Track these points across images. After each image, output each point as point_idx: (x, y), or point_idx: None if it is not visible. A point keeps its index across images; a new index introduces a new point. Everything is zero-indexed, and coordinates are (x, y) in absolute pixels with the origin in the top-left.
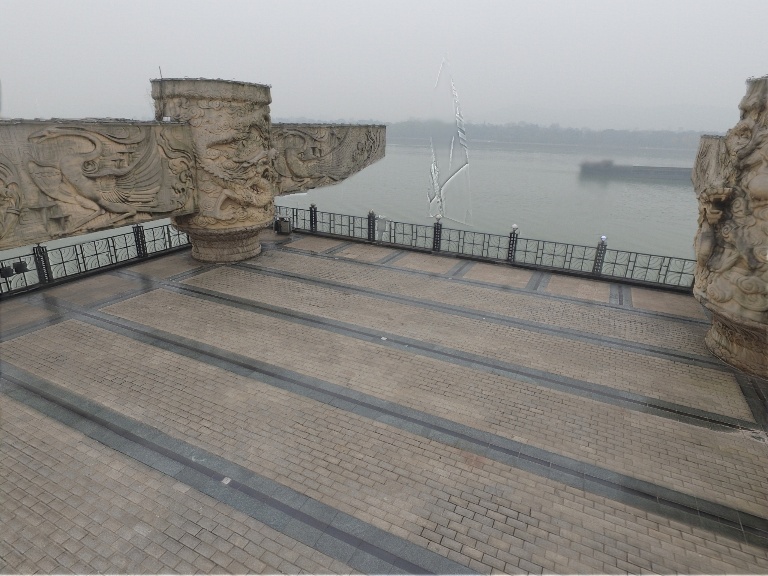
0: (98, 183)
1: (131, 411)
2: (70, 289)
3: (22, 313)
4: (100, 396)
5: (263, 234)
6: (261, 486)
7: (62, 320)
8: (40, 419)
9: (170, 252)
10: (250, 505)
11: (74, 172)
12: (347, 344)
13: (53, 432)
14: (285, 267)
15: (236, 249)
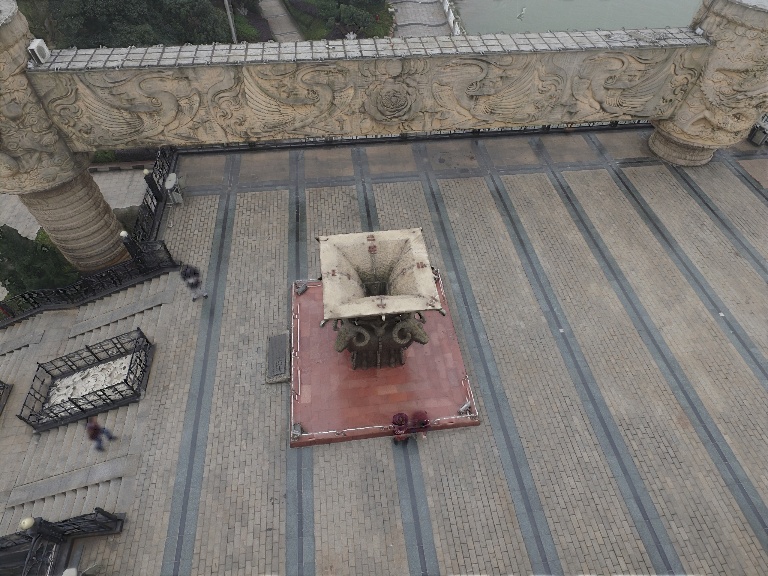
0: (609, 92)
1: (544, 263)
2: (555, 141)
3: (524, 153)
4: (535, 244)
5: None
6: (573, 345)
7: (540, 171)
8: (509, 242)
9: (635, 127)
10: (563, 349)
11: (598, 84)
12: (689, 300)
13: (511, 253)
14: (714, 193)
15: (685, 155)
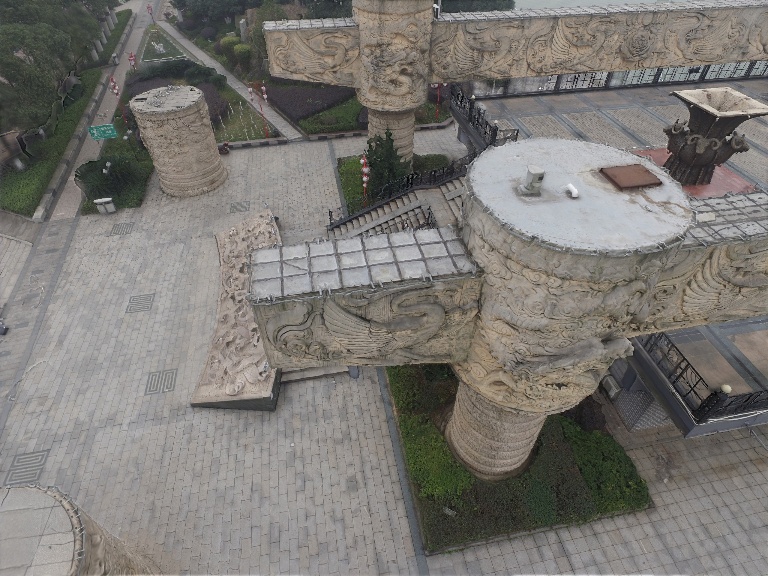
0: None
1: (756, 141)
2: (711, 86)
3: None
4: (742, 133)
5: None
6: None
7: None
8: None
9: (761, 77)
10: None
11: (766, 31)
12: None
13: None
14: None
15: None
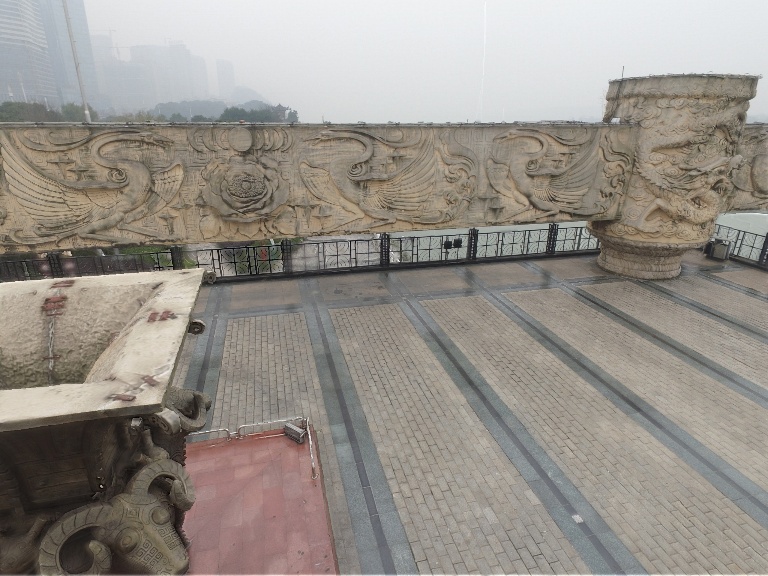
0: (535, 181)
1: (506, 398)
2: (485, 269)
3: (449, 280)
4: (485, 372)
5: (686, 254)
6: (615, 550)
7: (474, 294)
8: (441, 372)
9: (576, 254)
10: (597, 564)
11: (519, 170)
12: None
13: (446, 387)
14: (708, 301)
15: (649, 266)
